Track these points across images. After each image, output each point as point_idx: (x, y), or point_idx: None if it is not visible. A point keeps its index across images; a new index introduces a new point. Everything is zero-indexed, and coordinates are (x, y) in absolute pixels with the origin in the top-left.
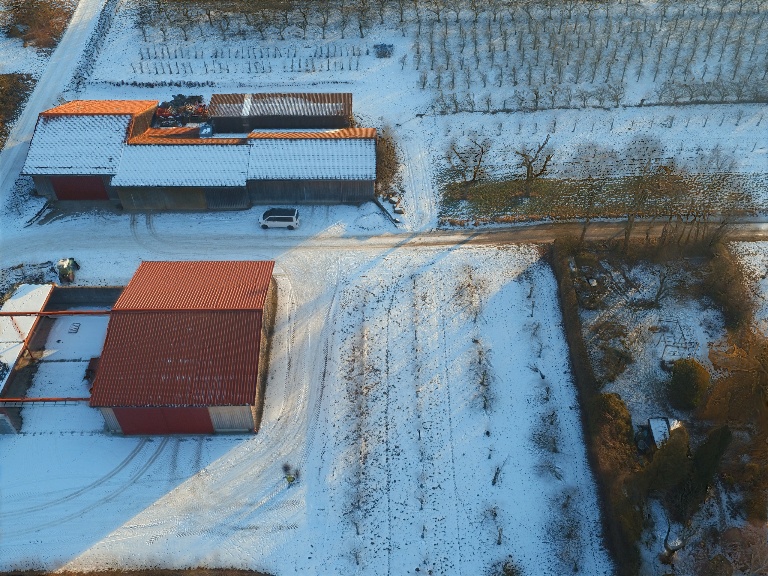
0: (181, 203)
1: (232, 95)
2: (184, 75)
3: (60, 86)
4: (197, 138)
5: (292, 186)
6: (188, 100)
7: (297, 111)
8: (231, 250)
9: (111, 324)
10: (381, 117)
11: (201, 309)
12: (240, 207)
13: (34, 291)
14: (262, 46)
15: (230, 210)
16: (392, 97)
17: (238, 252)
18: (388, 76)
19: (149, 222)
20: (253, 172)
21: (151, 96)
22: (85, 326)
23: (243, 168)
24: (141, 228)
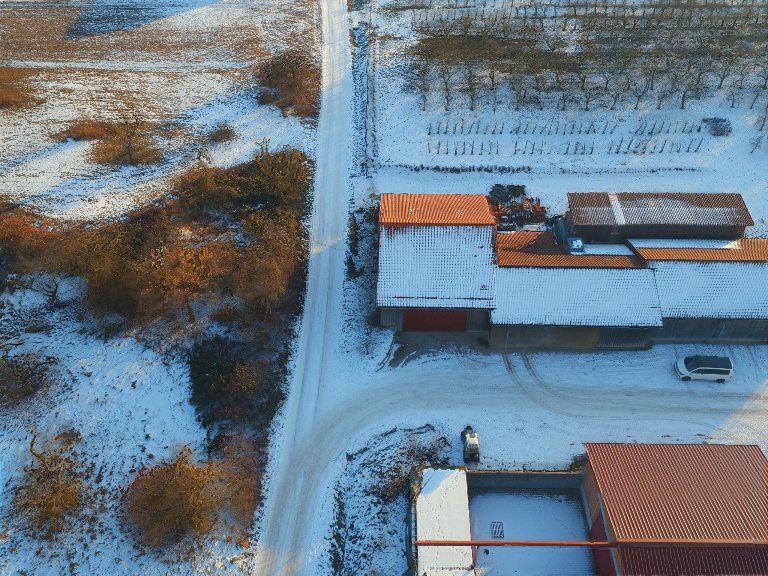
0: (564, 341)
1: (592, 195)
2: (491, 157)
3: (343, 169)
4: (569, 254)
5: (710, 323)
6: (511, 192)
7: (684, 219)
8: (657, 413)
9: (626, 565)
10: (761, 219)
11: (740, 543)
12: (636, 346)
13: (446, 481)
14: (566, 118)
15: (624, 350)
16: (760, 191)
17: (669, 417)
18: (738, 161)
19: (529, 366)
20: (667, 307)
21: (459, 184)
22: (509, 526)
23: (653, 301)
24: (523, 375)
